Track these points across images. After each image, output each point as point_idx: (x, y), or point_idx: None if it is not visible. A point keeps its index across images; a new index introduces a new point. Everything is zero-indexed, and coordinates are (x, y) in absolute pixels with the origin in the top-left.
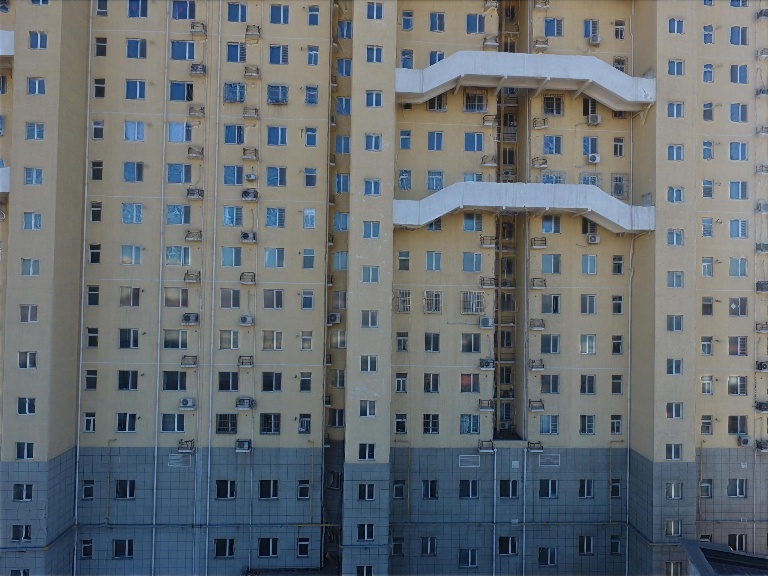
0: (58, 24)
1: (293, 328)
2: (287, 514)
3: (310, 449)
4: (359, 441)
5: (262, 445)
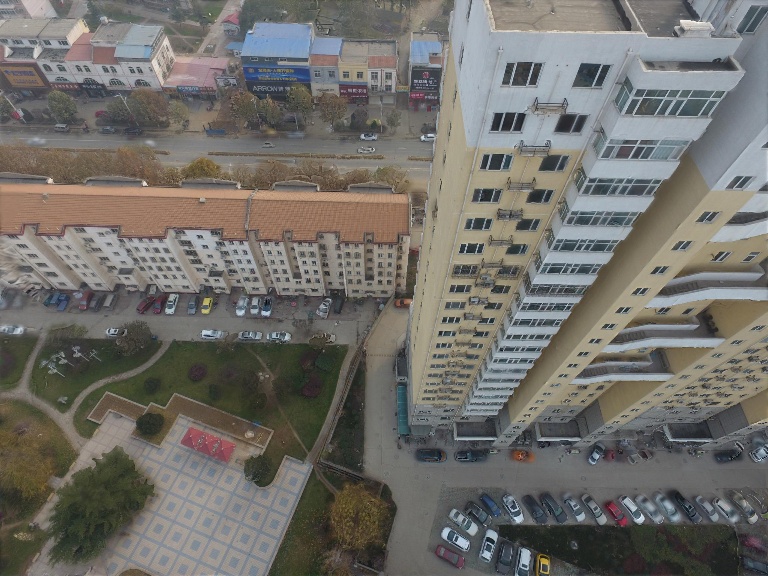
0: (758, 338)
1: (755, 386)
2: (696, 416)
3: (725, 408)
4: (762, 422)
5: (703, 406)
